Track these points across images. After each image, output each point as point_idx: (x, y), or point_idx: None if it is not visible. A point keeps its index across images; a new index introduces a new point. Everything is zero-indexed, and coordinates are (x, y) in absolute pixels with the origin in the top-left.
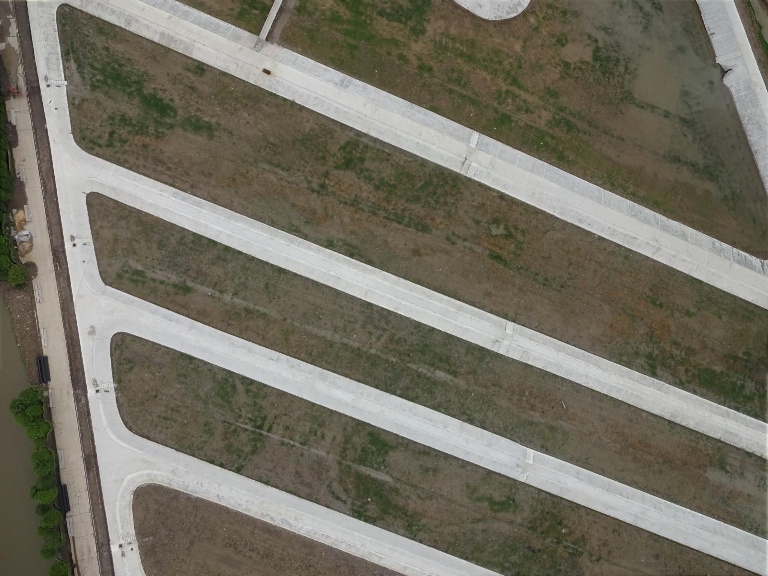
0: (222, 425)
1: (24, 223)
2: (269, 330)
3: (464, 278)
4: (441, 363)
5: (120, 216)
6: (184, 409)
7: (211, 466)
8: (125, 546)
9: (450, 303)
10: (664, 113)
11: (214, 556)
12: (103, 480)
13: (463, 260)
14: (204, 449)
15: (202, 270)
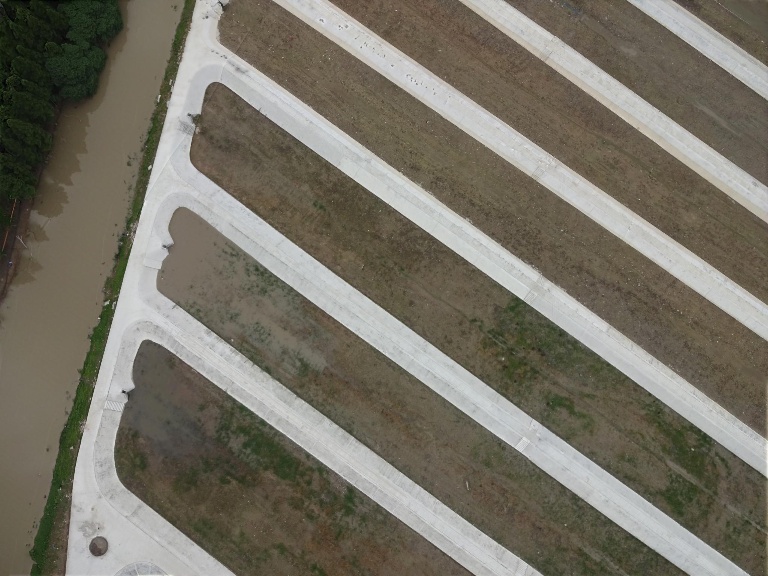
0: None
1: None
2: None
3: None
4: (593, 569)
5: None
6: None
7: None
8: None
9: None
10: None
11: None
12: None
13: None
14: None
15: None
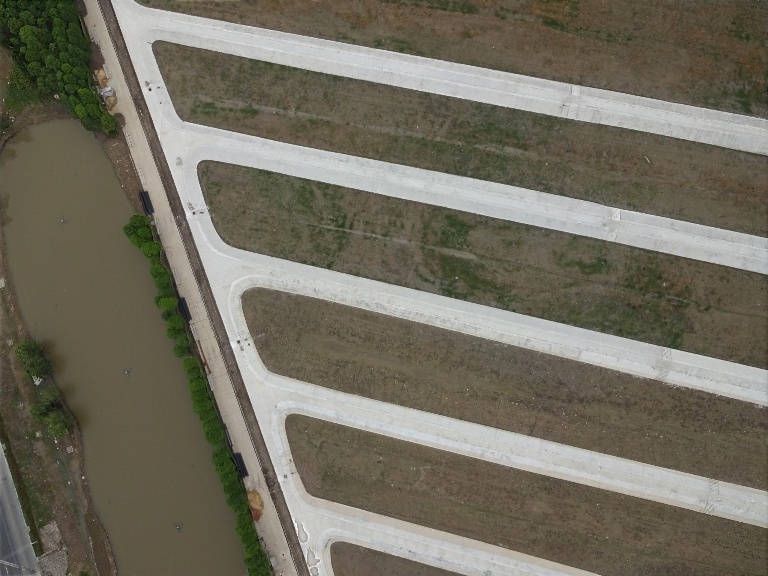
0: (307, 229)
1: (106, 81)
2: (335, 136)
3: (520, 51)
4: (508, 139)
5: (183, 58)
6: (271, 219)
7: (304, 266)
8: (242, 342)
9: (508, 77)
10: None
11: (321, 344)
12: (213, 288)
13: (516, 33)
14: (295, 252)
15: (264, 92)
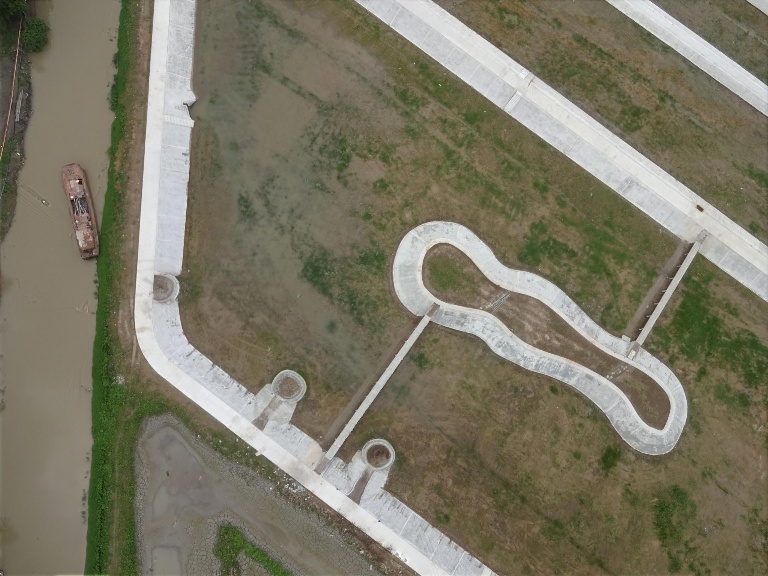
0: None
1: None
2: None
3: None
4: None
5: None
6: None
7: None
8: None
9: None
10: (287, 83)
11: None
12: None
13: (551, 3)
14: None
15: None
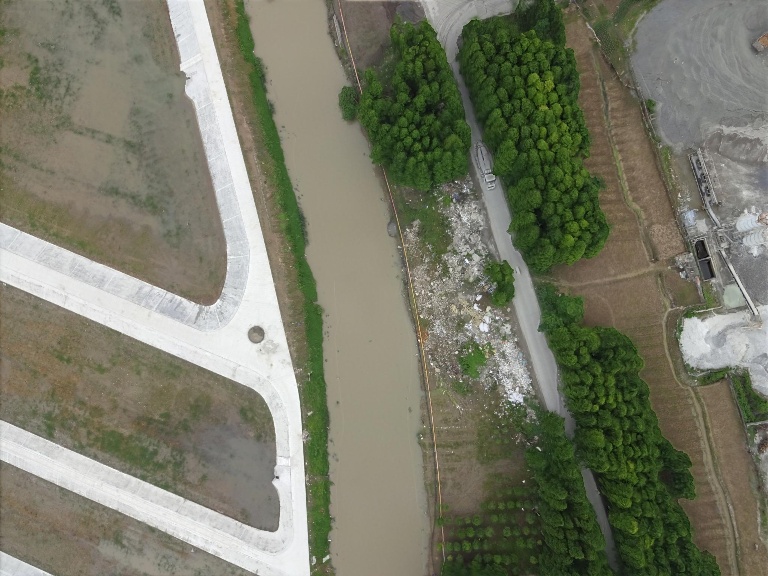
0: None
1: None
2: None
3: None
4: None
5: None
6: None
7: None
8: None
9: None
10: (107, 138)
11: None
12: None
13: None
14: None
15: None
